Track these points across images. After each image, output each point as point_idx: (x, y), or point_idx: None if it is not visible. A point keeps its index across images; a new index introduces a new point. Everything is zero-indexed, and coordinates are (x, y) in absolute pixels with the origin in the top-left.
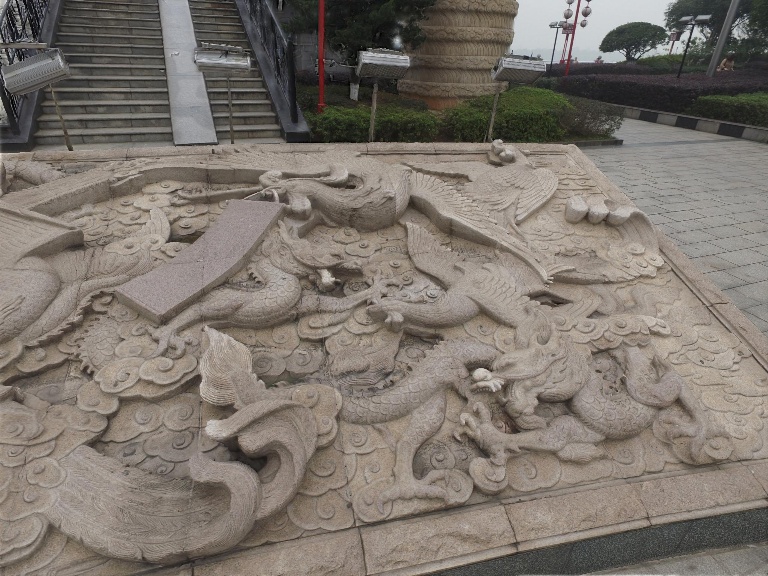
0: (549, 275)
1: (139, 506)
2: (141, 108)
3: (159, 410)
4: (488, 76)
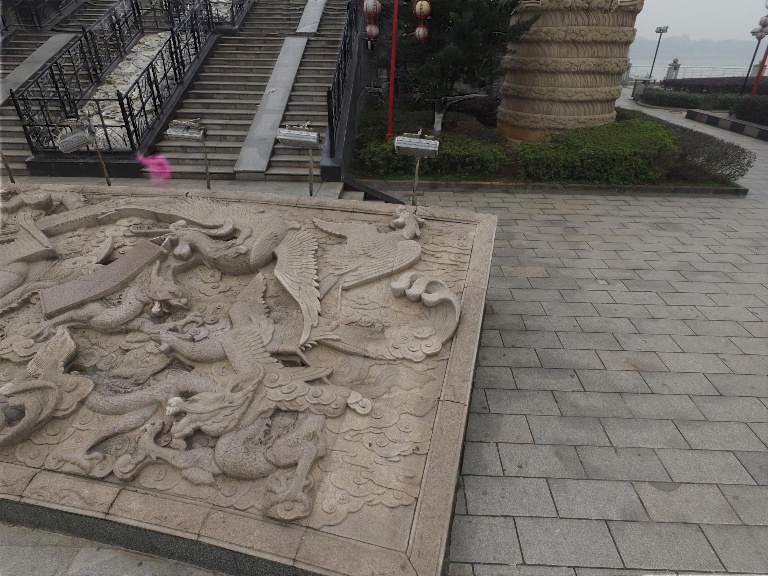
0: (313, 340)
1: None
2: (228, 138)
3: (17, 370)
4: (585, 108)
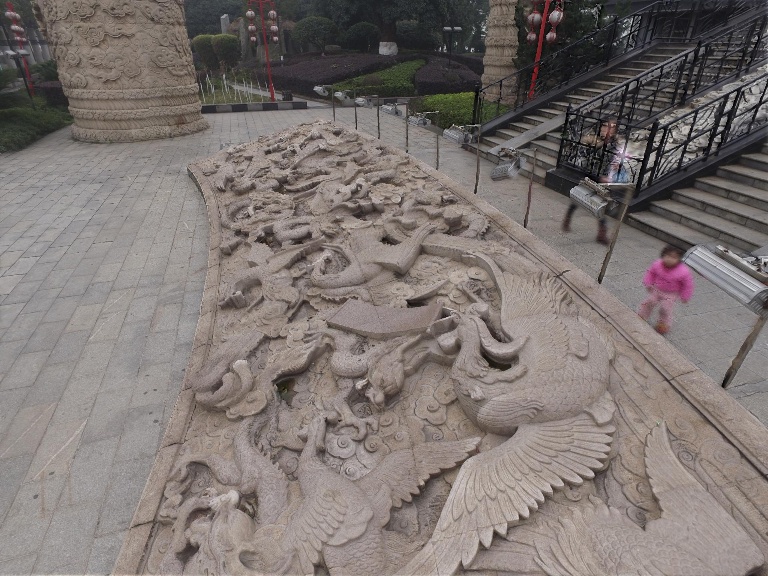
0: None
1: None
2: None
3: None
4: None
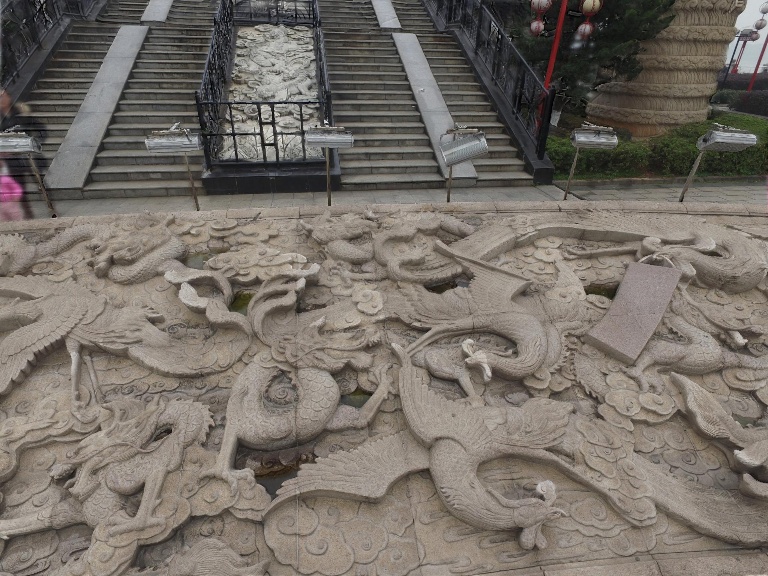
0: None
1: (706, 503)
2: (406, 142)
3: (657, 432)
4: (694, 104)
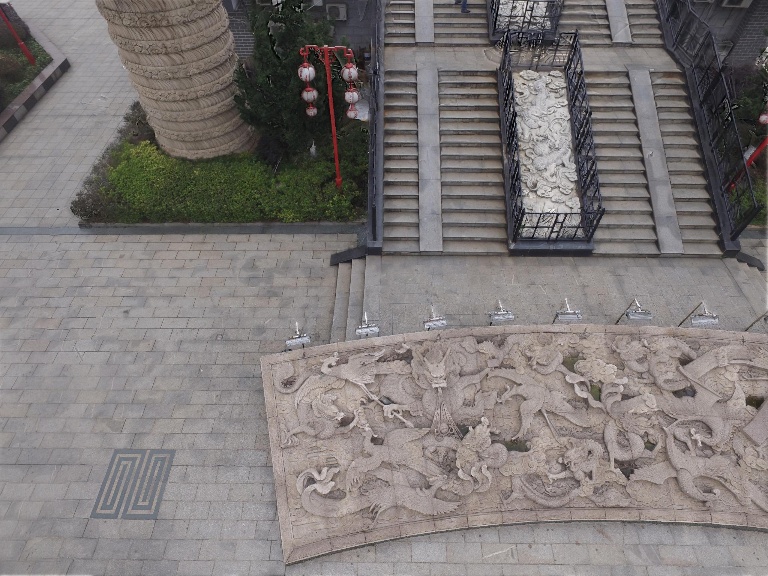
0: None
1: None
2: (635, 212)
3: (759, 473)
4: None
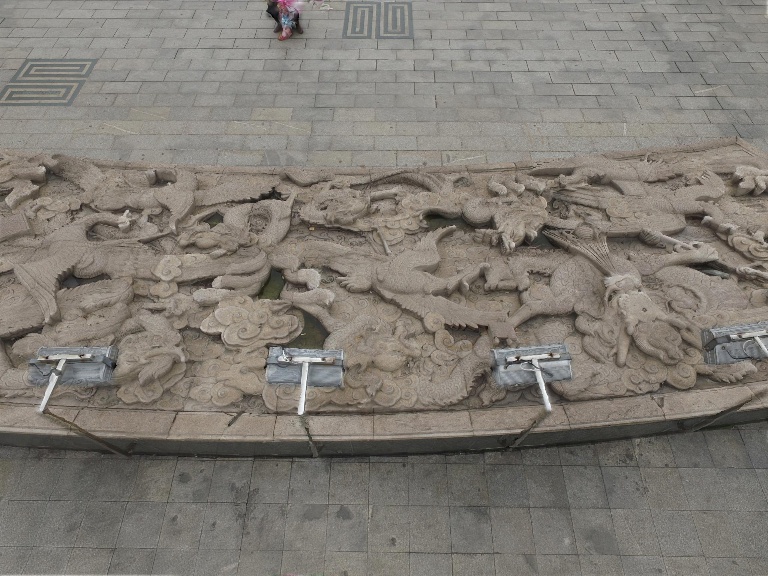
0: None
1: None
2: None
3: None
4: None
